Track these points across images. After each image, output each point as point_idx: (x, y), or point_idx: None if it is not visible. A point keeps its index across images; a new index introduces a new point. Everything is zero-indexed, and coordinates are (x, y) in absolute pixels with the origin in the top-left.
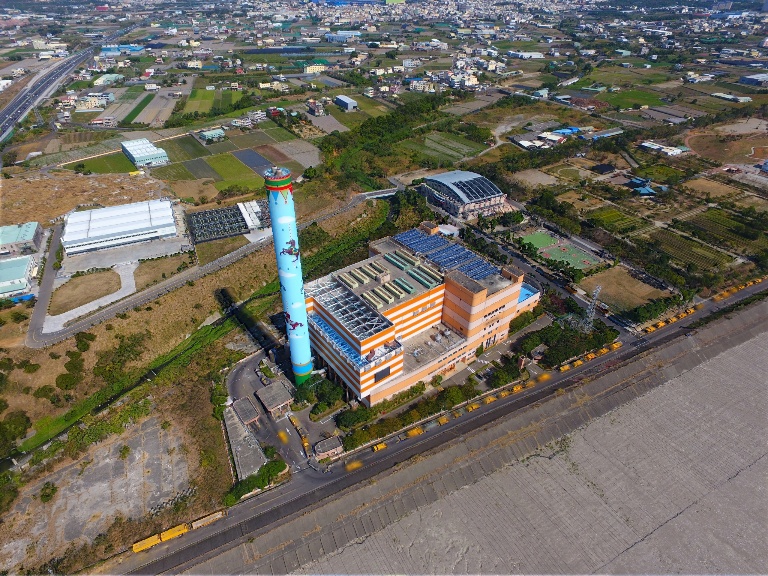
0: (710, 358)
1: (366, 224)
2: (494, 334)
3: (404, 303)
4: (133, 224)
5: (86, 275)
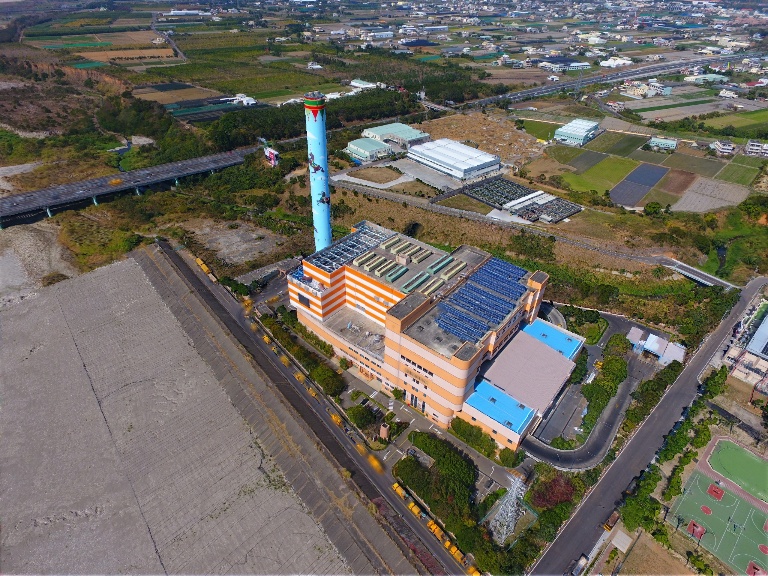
0: None
1: (610, 280)
2: (423, 399)
3: (366, 276)
4: (448, 158)
5: (391, 170)
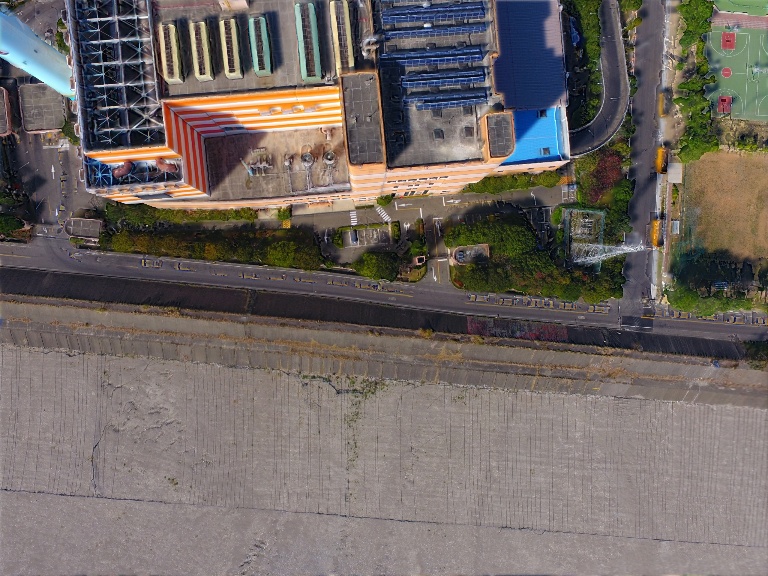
0: (701, 402)
1: None
2: (425, 189)
3: (223, 98)
4: None
5: None
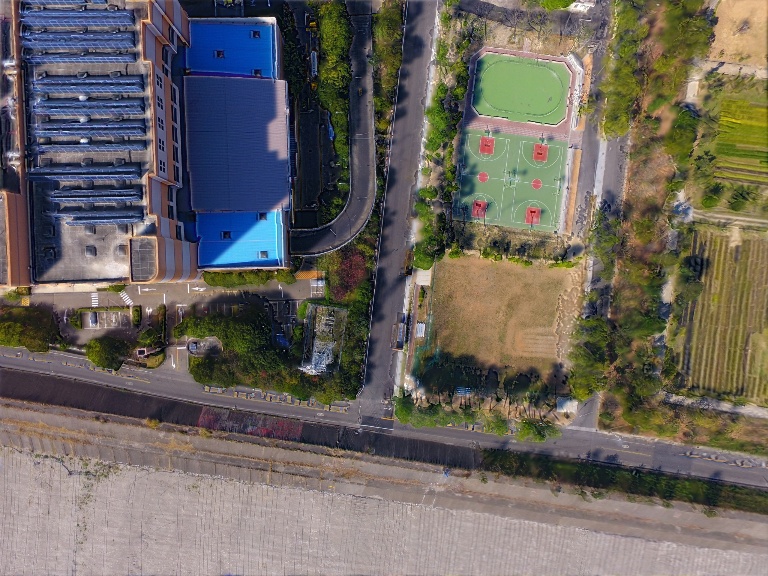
0: (440, 506)
1: None
2: None
3: None
4: None
5: None
